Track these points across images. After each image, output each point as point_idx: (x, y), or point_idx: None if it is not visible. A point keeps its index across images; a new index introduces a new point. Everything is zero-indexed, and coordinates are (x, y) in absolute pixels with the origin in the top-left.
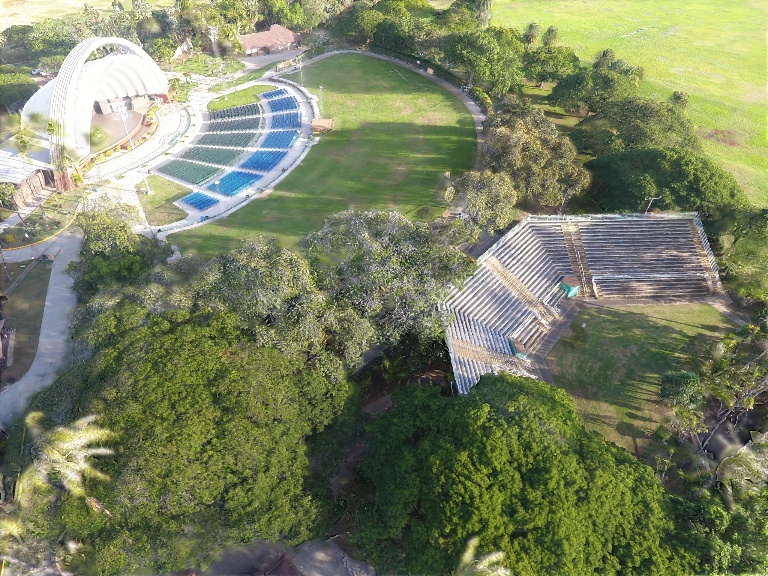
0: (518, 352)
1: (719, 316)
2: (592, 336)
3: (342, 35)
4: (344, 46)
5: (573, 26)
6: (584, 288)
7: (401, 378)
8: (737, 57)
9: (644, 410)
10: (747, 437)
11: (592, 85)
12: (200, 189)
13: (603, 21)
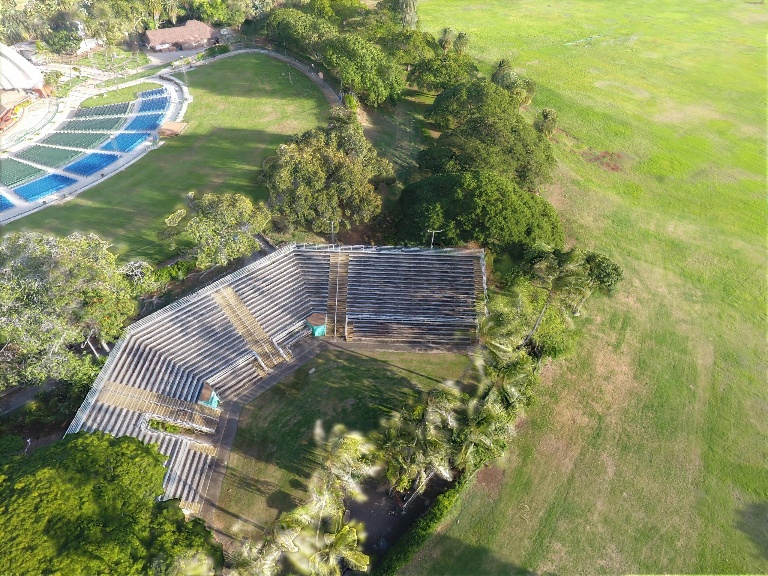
0: (200, 400)
1: (470, 370)
2: (312, 384)
3: (255, 33)
4: (251, 45)
5: (520, 31)
6: (335, 327)
7: (66, 420)
8: (678, 72)
9: (314, 478)
10: (410, 521)
11: (465, 98)
12: (7, 192)
13: (556, 27)
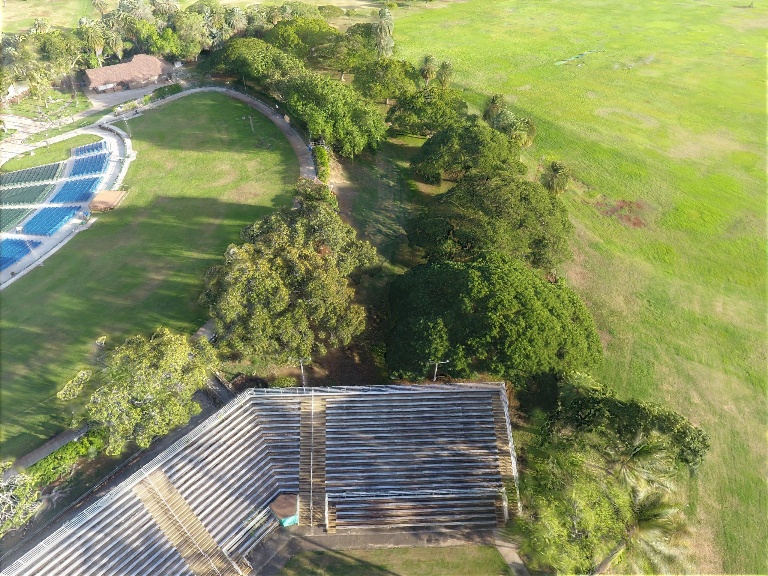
0: None
1: (502, 574)
2: None
3: (212, 68)
4: (207, 82)
5: (505, 50)
6: None
7: None
8: (683, 92)
9: None
10: None
11: (457, 148)
12: None
13: (543, 43)
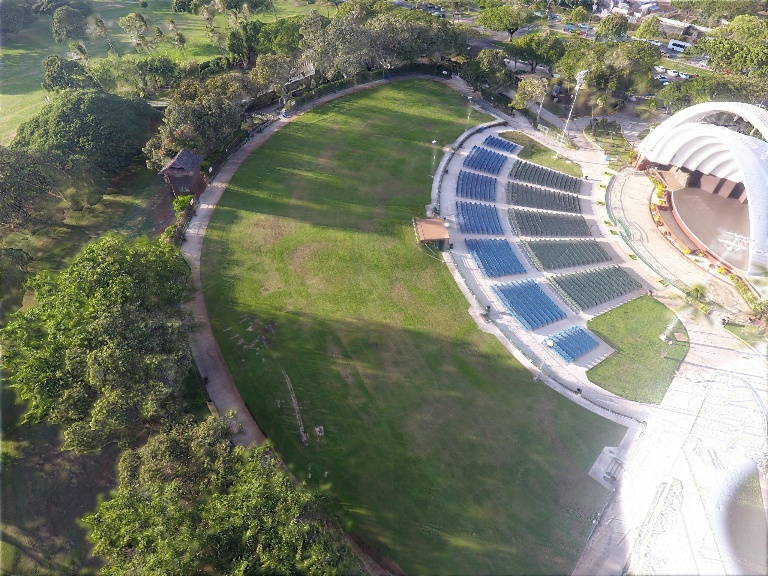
0: None
1: None
2: None
3: None
4: None
5: None
6: None
7: None
8: None
9: None
10: None
11: None
12: (514, 158)
13: None
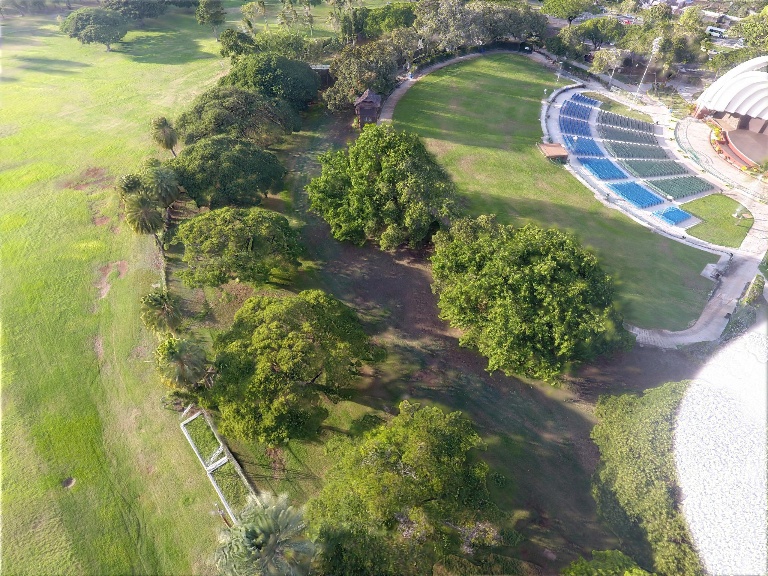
0: None
1: None
2: None
3: None
4: None
5: None
6: None
7: None
8: None
9: None
10: None
11: None
12: (597, 109)
13: None
